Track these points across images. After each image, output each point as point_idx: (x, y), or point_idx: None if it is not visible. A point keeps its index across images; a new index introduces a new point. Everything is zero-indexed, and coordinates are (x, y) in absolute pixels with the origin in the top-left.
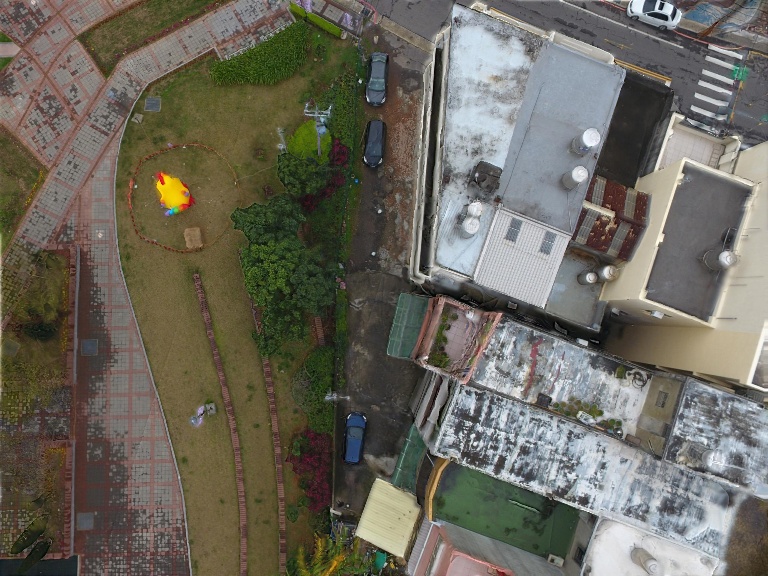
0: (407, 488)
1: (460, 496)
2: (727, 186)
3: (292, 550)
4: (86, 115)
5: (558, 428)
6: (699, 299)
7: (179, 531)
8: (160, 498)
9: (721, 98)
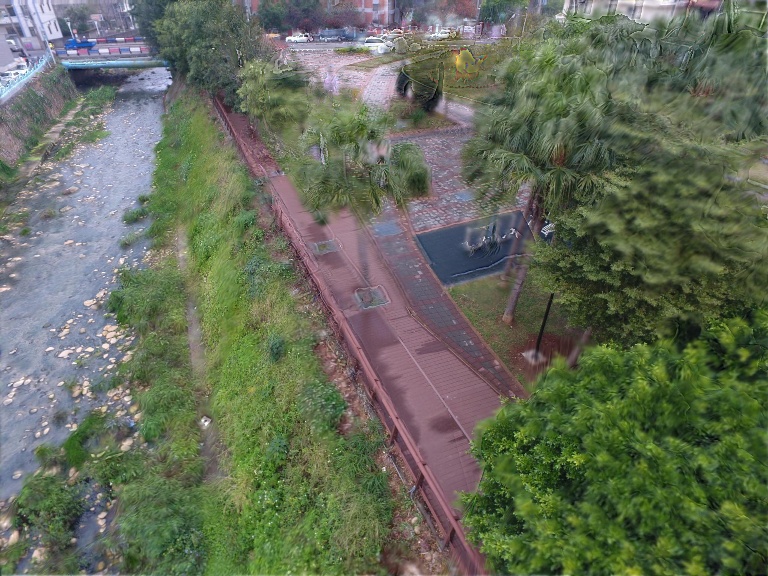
0: None
1: None
2: None
3: None
4: None
5: None
6: None
7: None
8: None
9: None
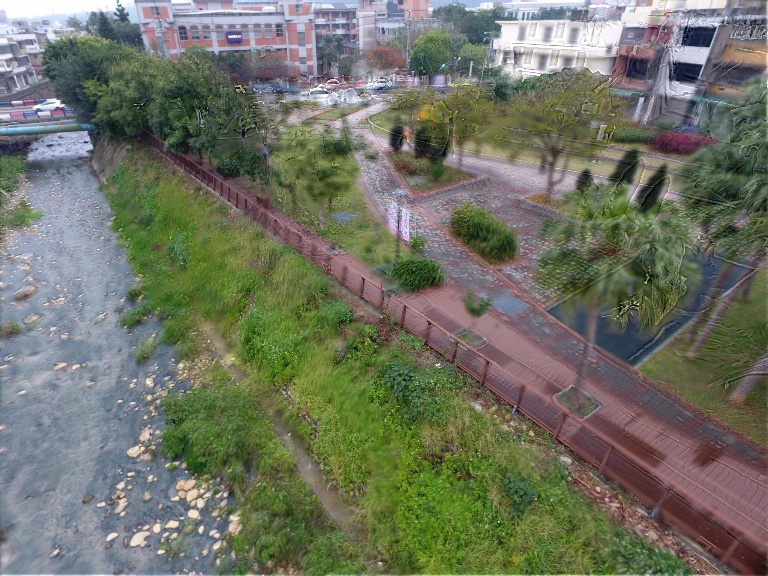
0: None
1: None
2: None
3: None
4: None
5: None
6: None
7: None
8: None
9: None
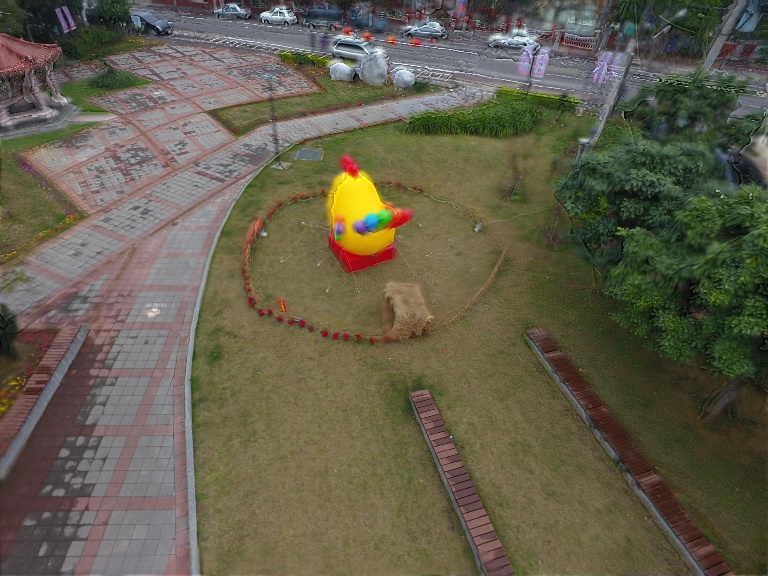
0: None
1: None
2: None
3: None
4: (192, 163)
5: None
6: None
7: None
8: None
9: None
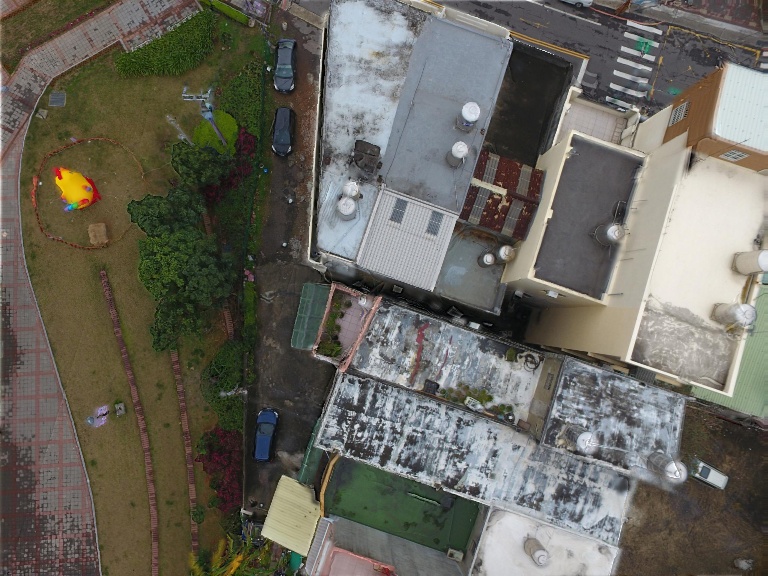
0: (313, 484)
1: (357, 490)
2: (618, 158)
3: (205, 553)
4: None
5: (446, 415)
6: (592, 276)
7: (89, 536)
8: (69, 503)
9: (641, 75)
